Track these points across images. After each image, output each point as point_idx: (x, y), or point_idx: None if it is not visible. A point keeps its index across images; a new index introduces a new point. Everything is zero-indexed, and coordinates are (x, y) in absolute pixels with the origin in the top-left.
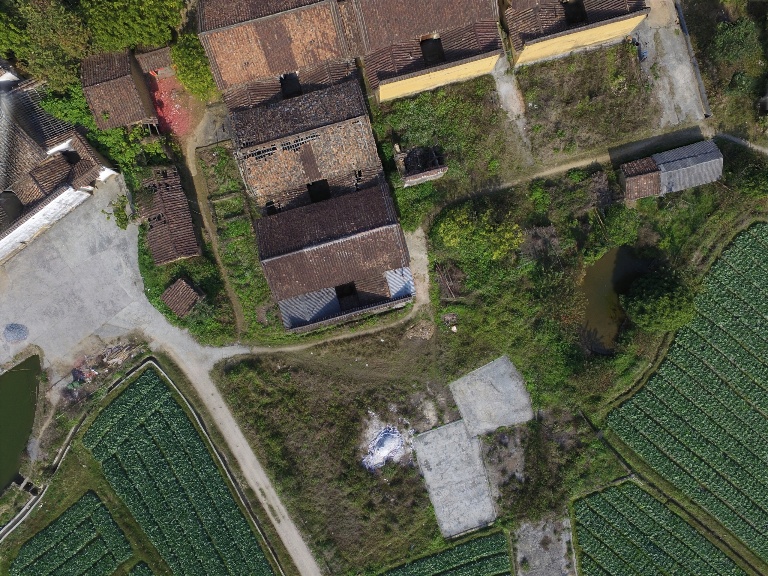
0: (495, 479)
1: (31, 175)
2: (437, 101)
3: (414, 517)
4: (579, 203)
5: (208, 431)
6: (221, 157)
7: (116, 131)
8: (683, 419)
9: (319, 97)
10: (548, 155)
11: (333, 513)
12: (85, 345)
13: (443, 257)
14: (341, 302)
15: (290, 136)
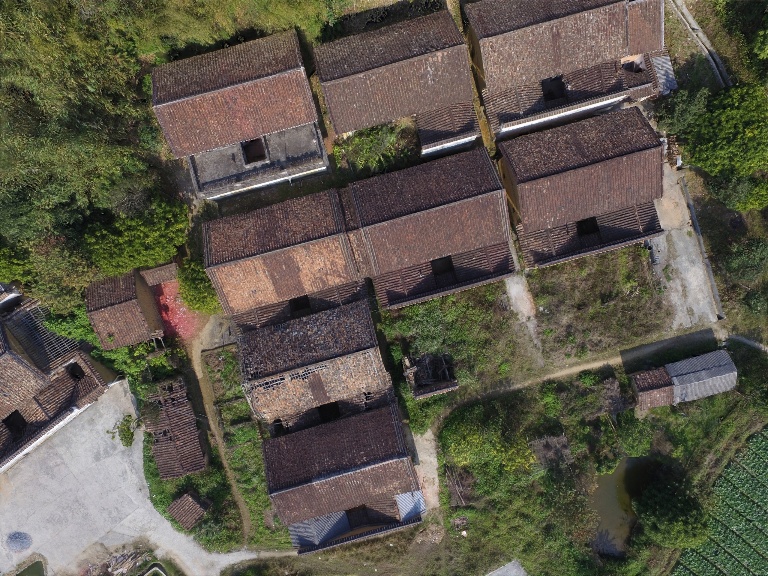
0: None
1: (35, 398)
2: (447, 308)
3: None
4: (591, 409)
5: None
6: (227, 362)
7: (121, 349)
8: None
9: (327, 320)
10: (559, 359)
11: None
12: (89, 553)
13: (453, 460)
14: (350, 517)
15: (298, 368)
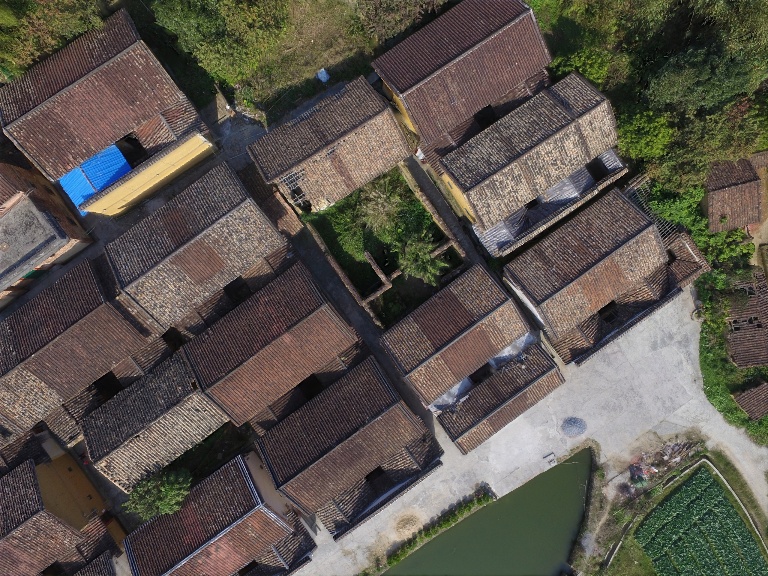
0: None
1: None
2: None
3: None
4: None
5: (760, 532)
6: None
7: (722, 233)
8: None
9: None
10: None
11: None
12: (642, 441)
13: None
14: None
15: None
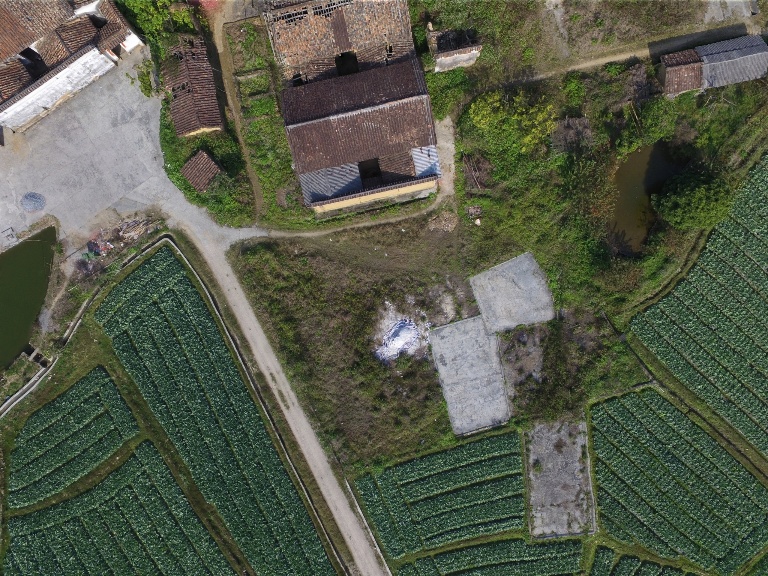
0: (511, 378)
1: (57, 33)
2: None
3: (426, 411)
4: (615, 97)
5: (221, 312)
6: (249, 33)
7: None
8: (710, 328)
9: None
10: (585, 46)
11: (343, 403)
12: (102, 218)
13: (470, 148)
14: (364, 183)
15: None
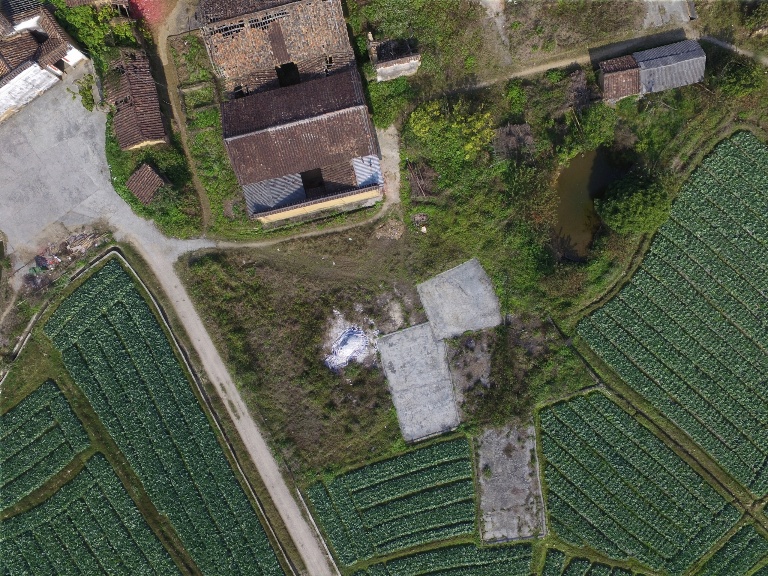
0: (460, 384)
1: None
2: None
3: (376, 418)
4: (556, 103)
5: (170, 324)
6: (192, 45)
7: (84, 9)
8: (655, 330)
9: None
10: (526, 53)
11: (294, 412)
12: (49, 232)
13: (415, 156)
14: (308, 193)
15: (258, 12)
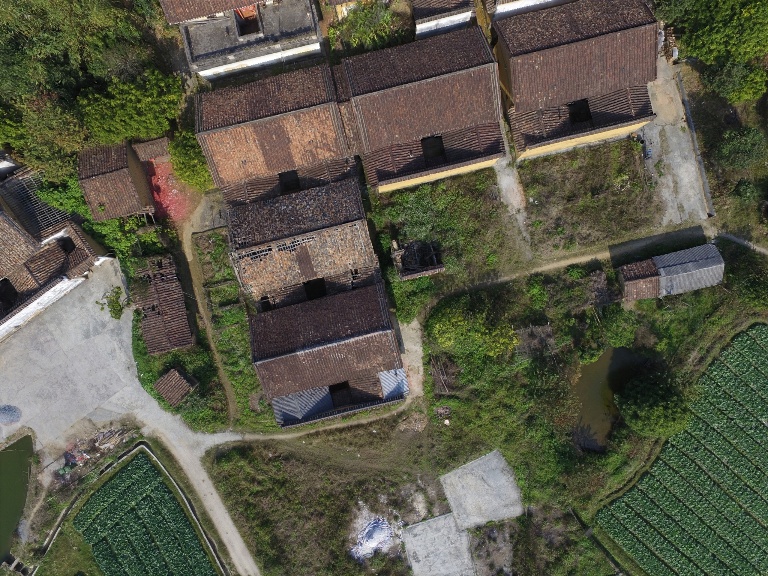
0: (483, 573)
1: (25, 265)
2: (436, 195)
3: None
4: (577, 301)
5: (198, 517)
6: (217, 244)
7: (111, 221)
8: (673, 519)
9: (317, 195)
10: (547, 251)
11: None
12: (77, 428)
13: (438, 350)
14: (334, 397)
15: (286, 238)
